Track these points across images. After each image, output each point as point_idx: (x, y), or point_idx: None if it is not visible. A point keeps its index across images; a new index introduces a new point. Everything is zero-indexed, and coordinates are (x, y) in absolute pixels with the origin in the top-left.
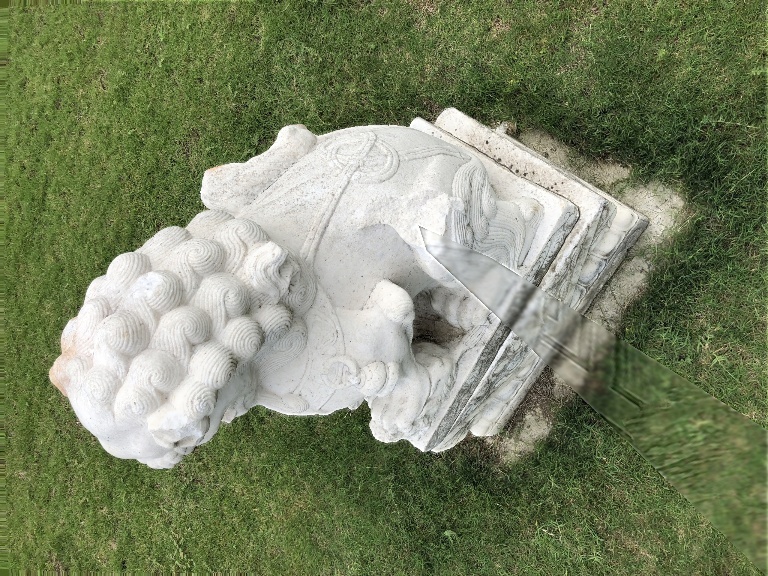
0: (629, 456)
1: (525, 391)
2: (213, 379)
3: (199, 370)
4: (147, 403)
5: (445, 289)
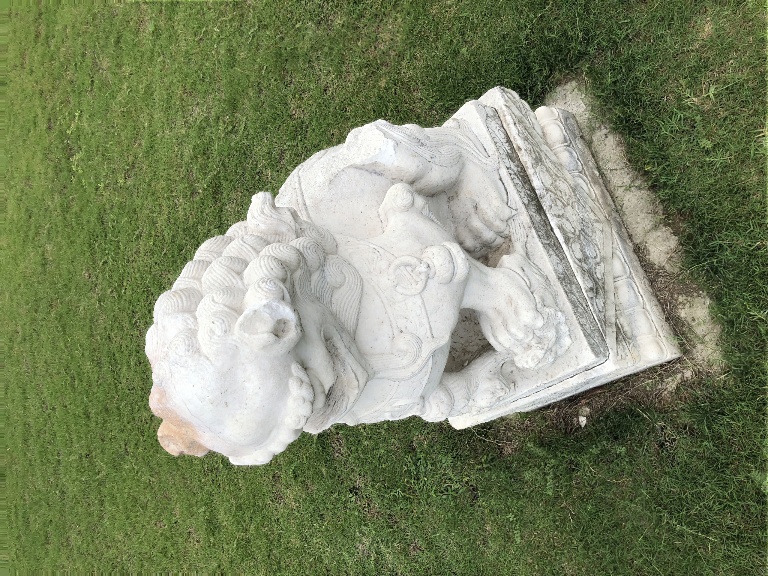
0: (767, 216)
1: (650, 295)
2: (267, 269)
3: (252, 274)
4: (223, 316)
5: (460, 223)
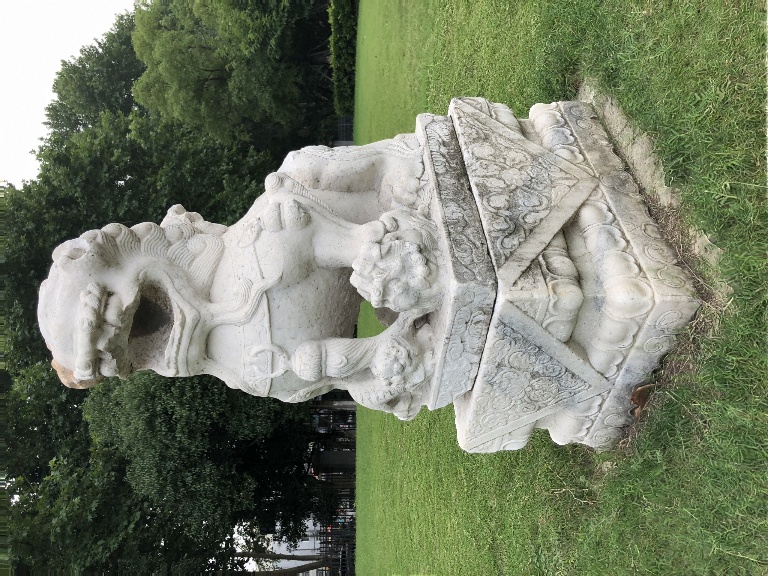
0: None
1: (652, 240)
2: None
3: None
4: None
5: None
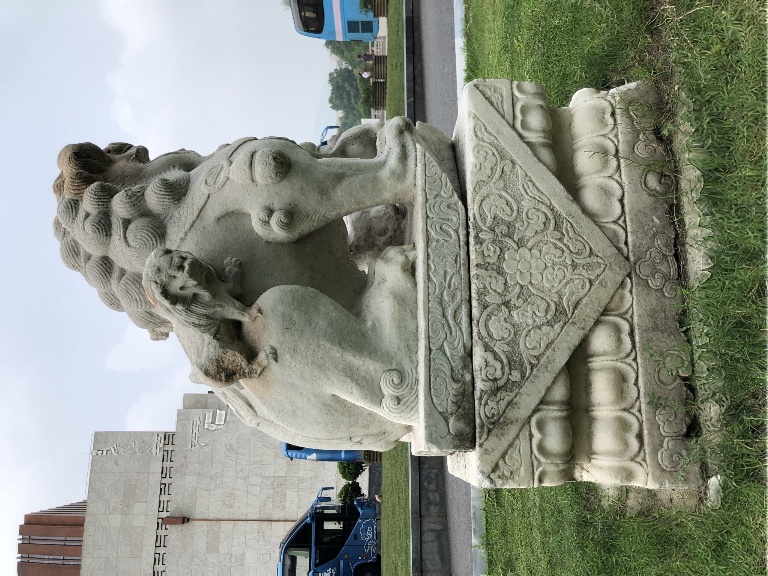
0: None
1: None
2: None
3: None
4: None
5: None
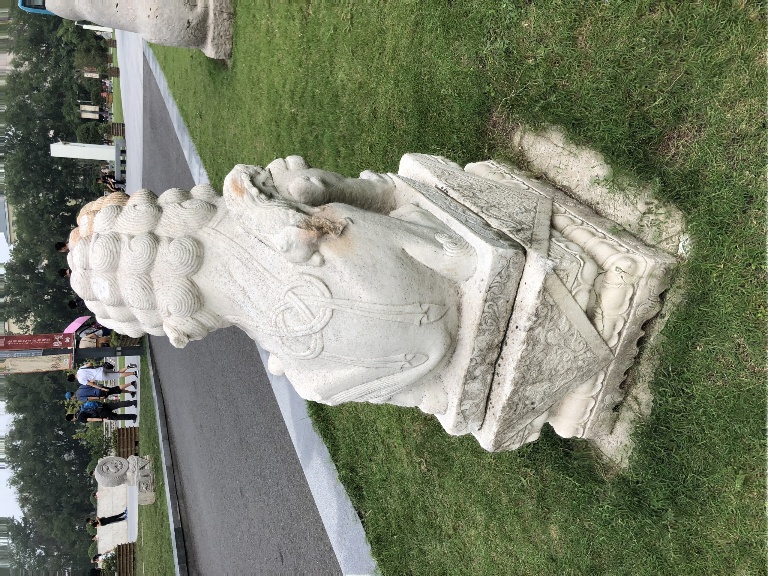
0: None
1: None
2: None
3: None
4: None
5: None
